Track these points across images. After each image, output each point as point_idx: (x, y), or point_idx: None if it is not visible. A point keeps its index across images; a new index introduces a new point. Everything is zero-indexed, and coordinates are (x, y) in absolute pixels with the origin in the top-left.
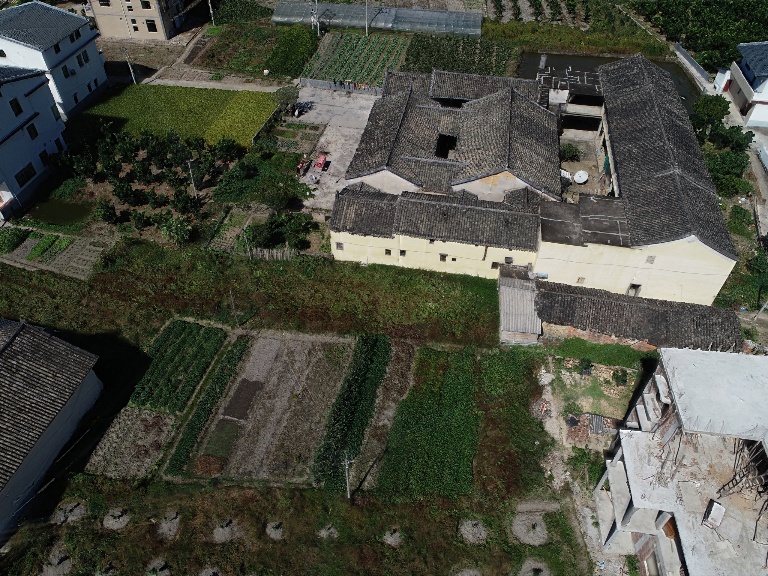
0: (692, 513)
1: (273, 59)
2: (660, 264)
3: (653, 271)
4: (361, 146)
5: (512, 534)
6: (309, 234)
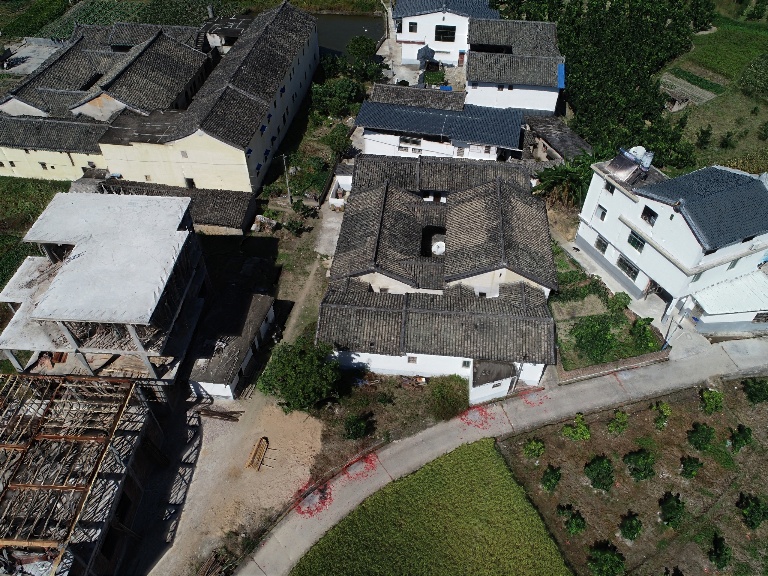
0: None
1: (13, 23)
2: (194, 158)
3: (193, 165)
4: (18, 84)
5: None
6: None
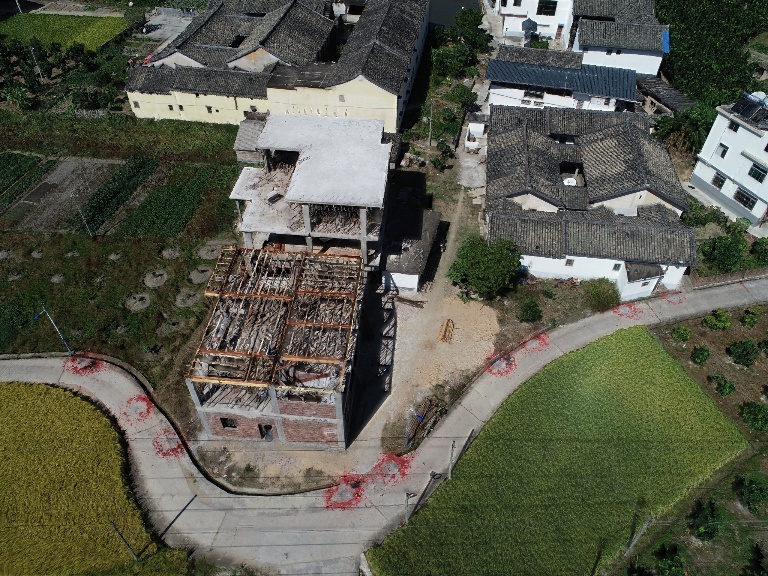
0: (263, 200)
1: None
2: (349, 102)
3: (347, 108)
4: (172, 42)
5: (196, 254)
6: (124, 103)
